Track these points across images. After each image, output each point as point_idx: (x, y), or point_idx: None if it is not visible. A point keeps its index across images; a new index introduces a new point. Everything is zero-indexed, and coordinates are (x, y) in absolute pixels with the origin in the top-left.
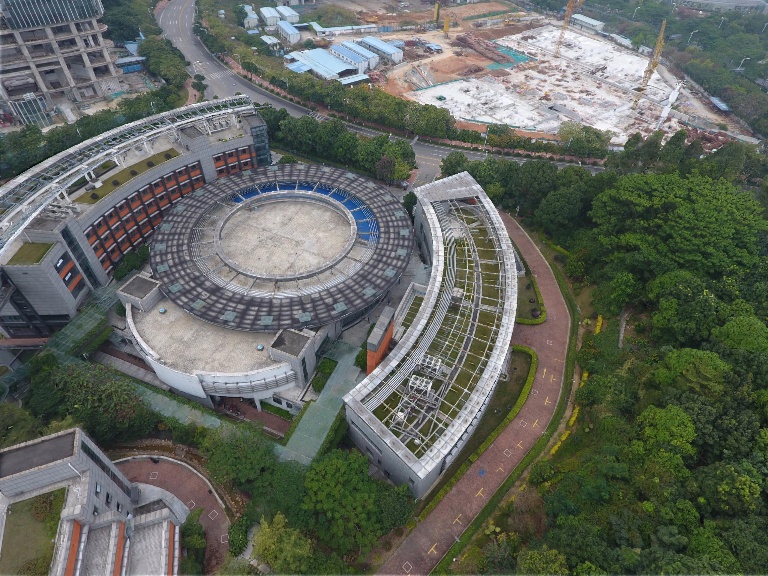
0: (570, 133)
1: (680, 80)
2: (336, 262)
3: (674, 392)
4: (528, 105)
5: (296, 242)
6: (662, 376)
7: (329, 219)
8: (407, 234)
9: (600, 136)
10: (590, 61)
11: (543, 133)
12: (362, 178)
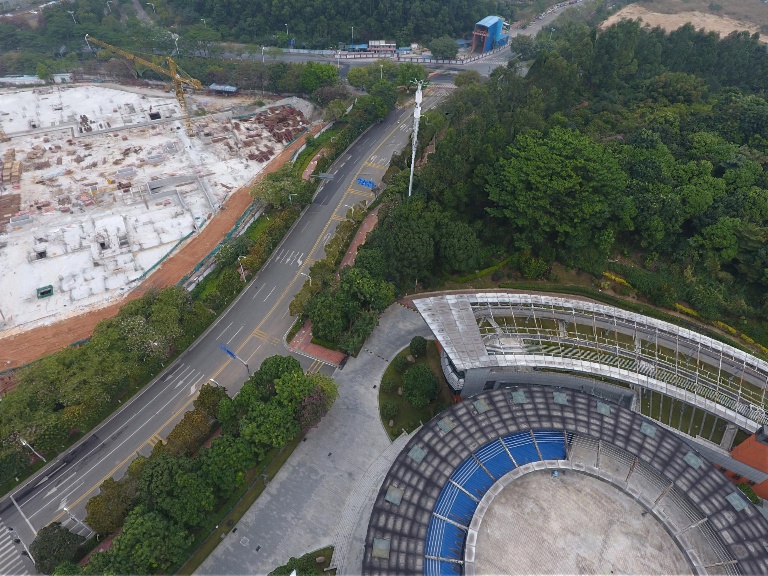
0: (277, 192)
1: (149, 87)
2: (648, 500)
3: (764, 252)
4: (131, 207)
5: (584, 572)
6: (734, 254)
7: (513, 508)
8: (563, 396)
9: (289, 174)
10: (52, 120)
11: (215, 216)
12: (424, 435)
